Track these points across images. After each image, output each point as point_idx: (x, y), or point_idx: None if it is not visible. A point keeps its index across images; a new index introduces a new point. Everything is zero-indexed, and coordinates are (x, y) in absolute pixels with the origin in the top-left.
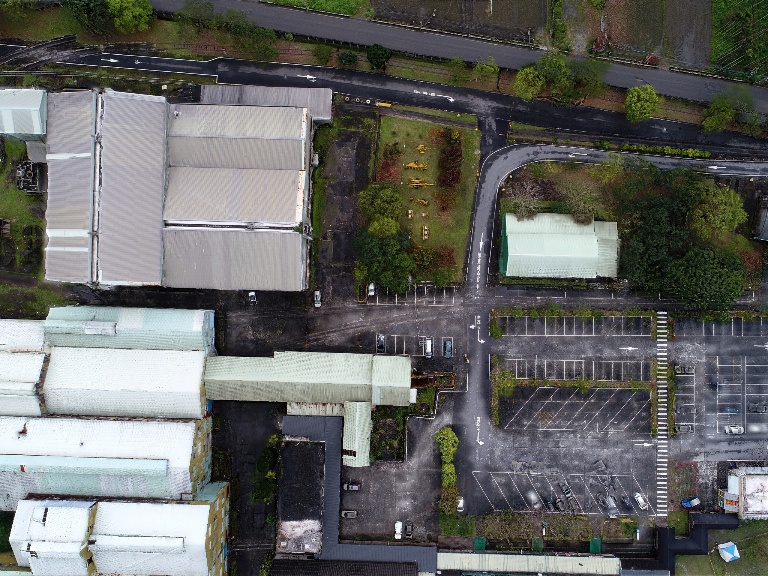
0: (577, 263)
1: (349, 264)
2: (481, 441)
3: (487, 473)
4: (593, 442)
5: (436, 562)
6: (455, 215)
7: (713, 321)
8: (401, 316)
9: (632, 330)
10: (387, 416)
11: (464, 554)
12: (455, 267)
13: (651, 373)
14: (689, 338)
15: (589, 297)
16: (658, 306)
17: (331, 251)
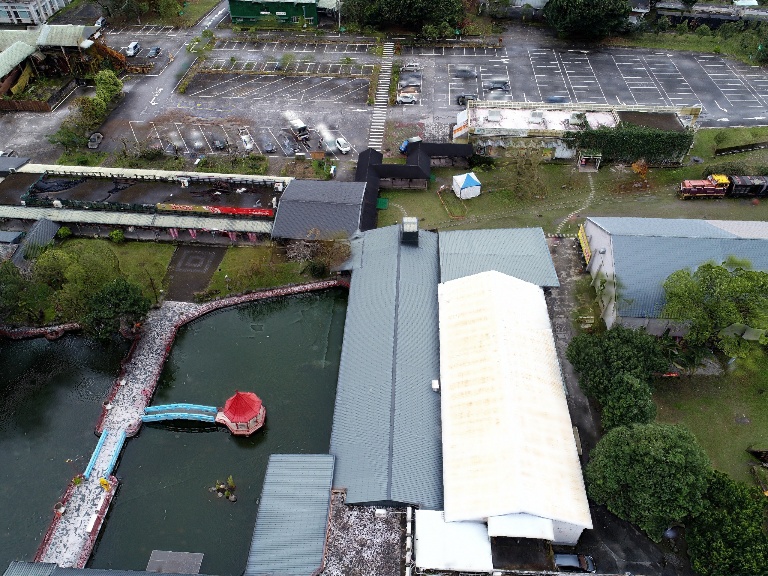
0: None
1: (89, 17)
2: (155, 102)
3: (148, 123)
4: (293, 107)
5: (18, 167)
6: (204, 1)
7: (443, 48)
8: (119, 38)
9: (356, 50)
10: (55, 85)
11: (66, 166)
12: (189, 19)
13: (373, 71)
14: (417, 55)
15: (316, 35)
16: (386, 41)
17: (77, 11)
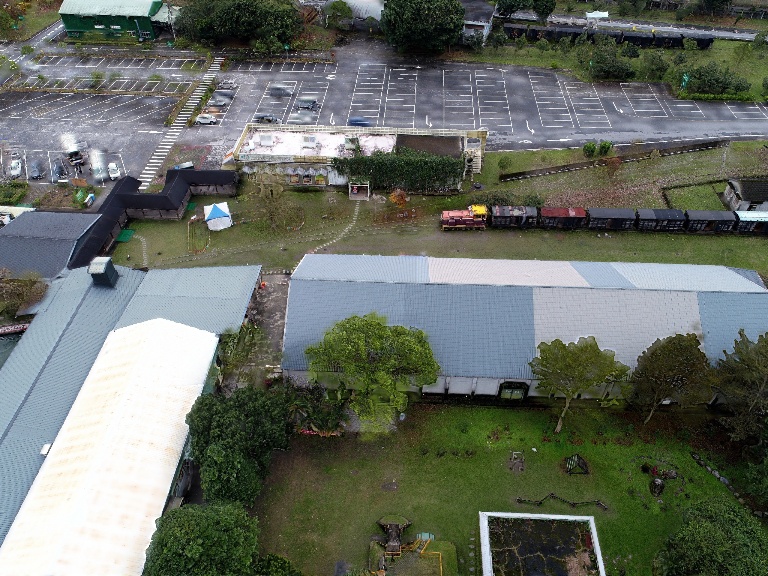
0: (130, 4)
1: None
2: None
3: None
4: (86, 128)
5: None
6: (51, 13)
7: (273, 64)
8: None
9: (182, 66)
10: None
11: None
12: (26, 32)
13: (188, 89)
14: (243, 71)
15: (149, 50)
16: (218, 55)
17: None
